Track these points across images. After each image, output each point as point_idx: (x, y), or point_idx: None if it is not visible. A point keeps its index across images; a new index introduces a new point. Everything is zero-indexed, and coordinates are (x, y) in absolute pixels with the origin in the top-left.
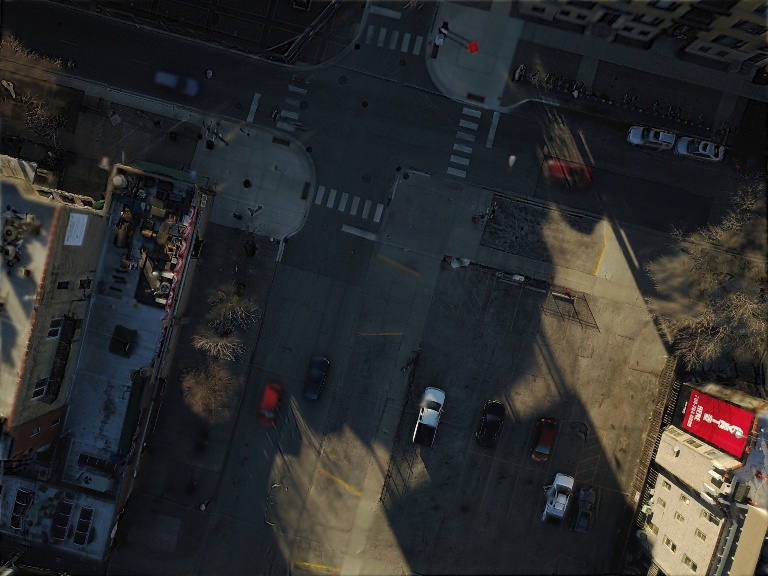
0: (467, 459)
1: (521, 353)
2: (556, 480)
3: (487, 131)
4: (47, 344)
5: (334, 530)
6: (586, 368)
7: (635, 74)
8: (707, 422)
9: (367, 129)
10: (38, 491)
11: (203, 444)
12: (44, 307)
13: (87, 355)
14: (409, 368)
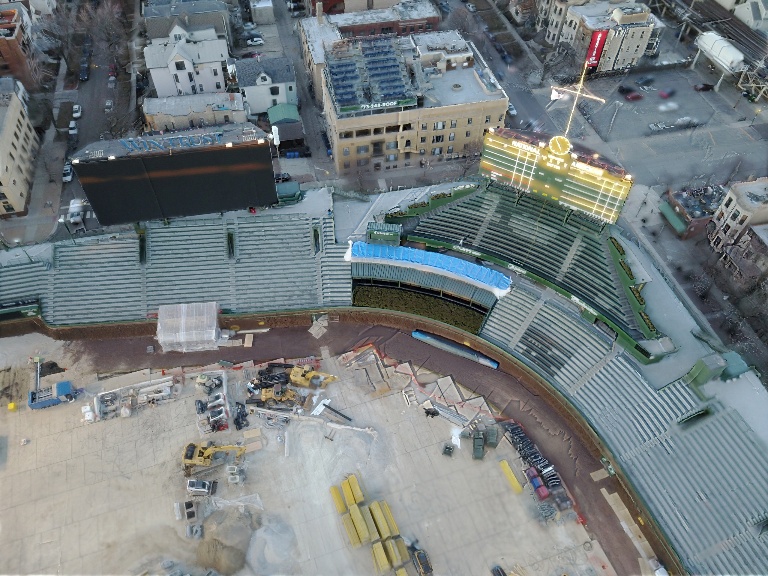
0: (663, 111)
1: None
2: (643, 90)
3: None
4: None
5: (730, 135)
6: None
7: None
8: None
9: None
10: None
11: None
12: None
13: None
14: (652, 136)
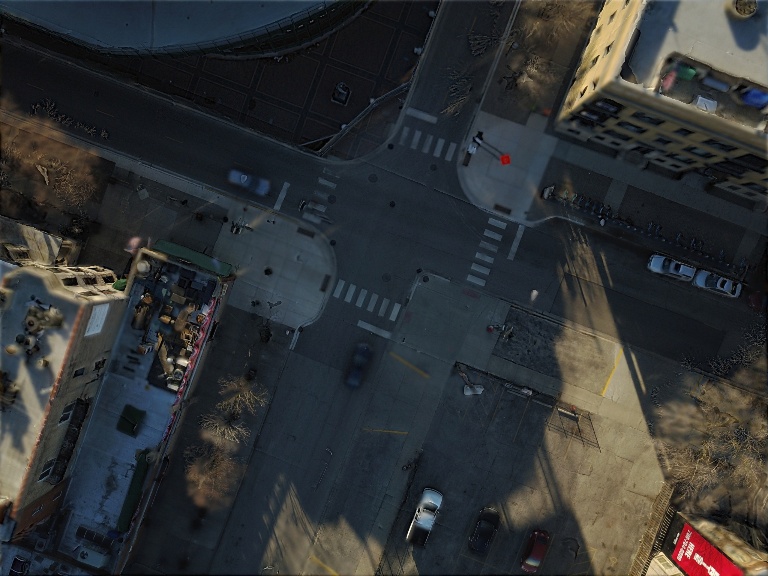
0: (458, 562)
1: (521, 464)
2: None
3: (510, 243)
4: (58, 430)
5: None
6: (583, 485)
7: (662, 202)
8: (697, 563)
9: (392, 229)
10: (34, 560)
11: (200, 521)
12: (59, 398)
13: (94, 430)
14: (410, 467)
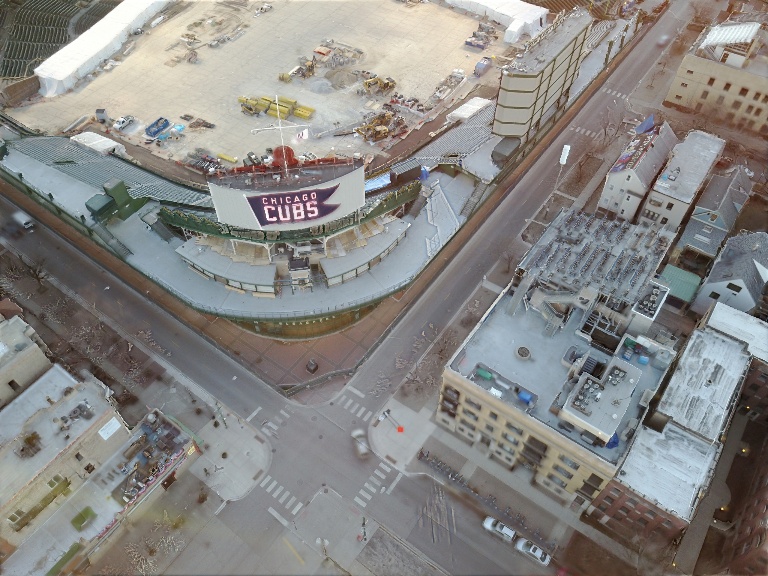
0: None
1: None
2: None
3: (391, 483)
4: (44, 487)
5: None
6: None
7: (500, 484)
8: None
9: (315, 452)
10: None
11: None
12: (61, 461)
13: (56, 519)
14: None
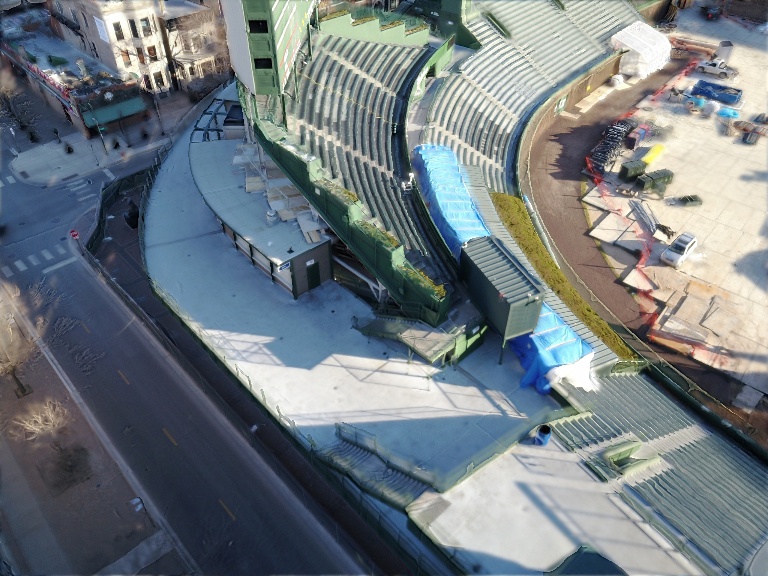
0: None
1: None
2: None
3: None
4: (68, 8)
5: None
6: None
7: None
8: None
9: (6, 218)
10: None
11: None
12: None
13: None
14: None
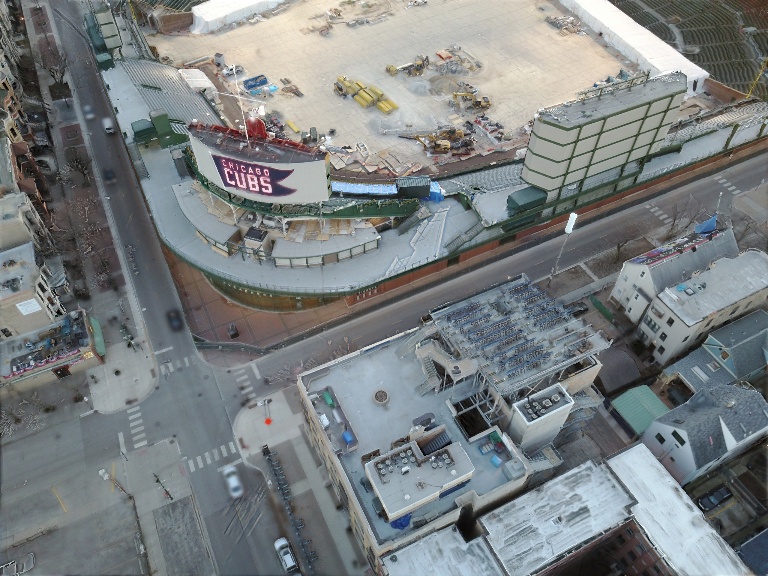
0: None
1: None
2: None
3: (227, 463)
4: None
5: None
6: None
7: (319, 515)
8: None
9: (187, 405)
10: None
11: None
12: None
13: None
14: None
